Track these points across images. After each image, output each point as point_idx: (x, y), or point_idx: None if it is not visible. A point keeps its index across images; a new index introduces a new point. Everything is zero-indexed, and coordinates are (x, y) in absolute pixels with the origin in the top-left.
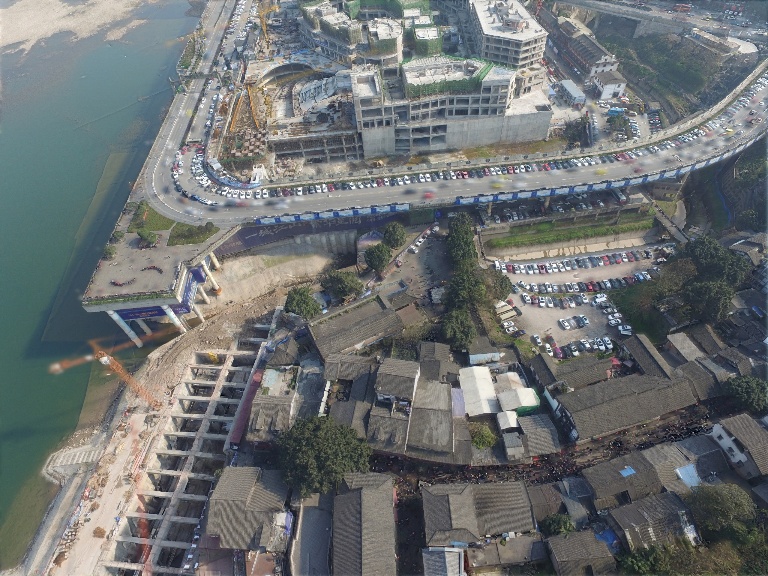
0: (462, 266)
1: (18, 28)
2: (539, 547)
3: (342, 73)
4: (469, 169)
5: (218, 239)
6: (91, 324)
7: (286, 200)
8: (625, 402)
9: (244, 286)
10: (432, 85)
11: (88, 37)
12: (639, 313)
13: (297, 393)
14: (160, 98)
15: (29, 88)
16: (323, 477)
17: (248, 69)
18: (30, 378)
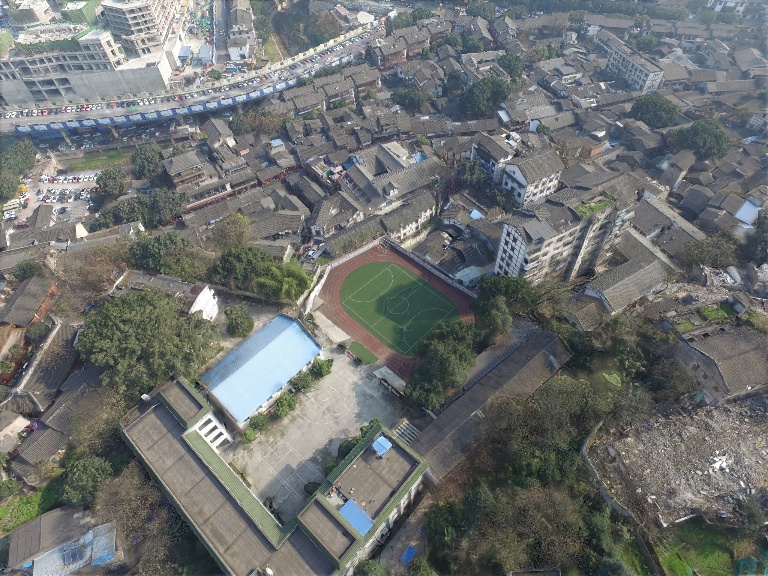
0: None
1: None
2: None
3: None
4: (53, 108)
5: None
6: None
7: None
8: None
9: None
10: (39, 44)
11: None
12: None
13: None
14: None
15: None
16: None
17: None
18: None
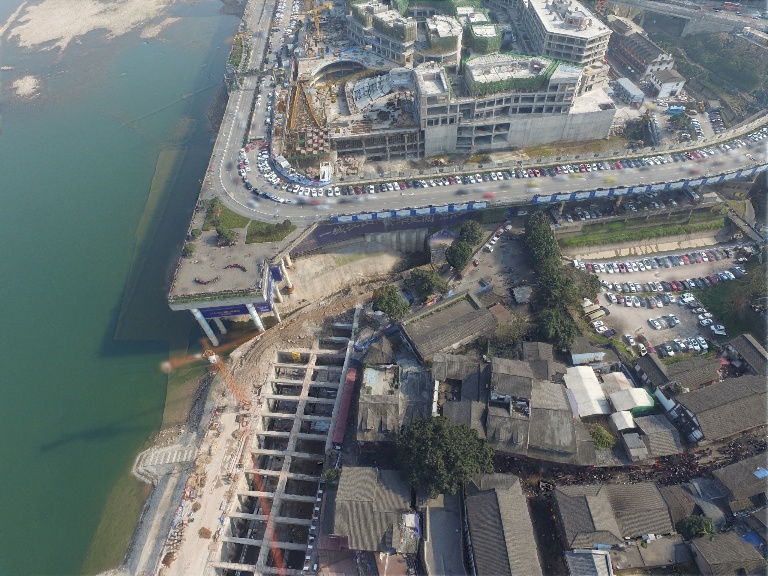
0: (546, 265)
1: (51, 25)
2: (682, 550)
3: (396, 71)
4: (540, 167)
5: (297, 237)
6: (163, 322)
7: (359, 198)
8: (748, 403)
9: (316, 285)
10: (499, 83)
11: (123, 34)
12: (734, 313)
13: (401, 393)
14: (204, 96)
15: (70, 85)
16: (453, 478)
17: (299, 67)
18: (108, 377)
